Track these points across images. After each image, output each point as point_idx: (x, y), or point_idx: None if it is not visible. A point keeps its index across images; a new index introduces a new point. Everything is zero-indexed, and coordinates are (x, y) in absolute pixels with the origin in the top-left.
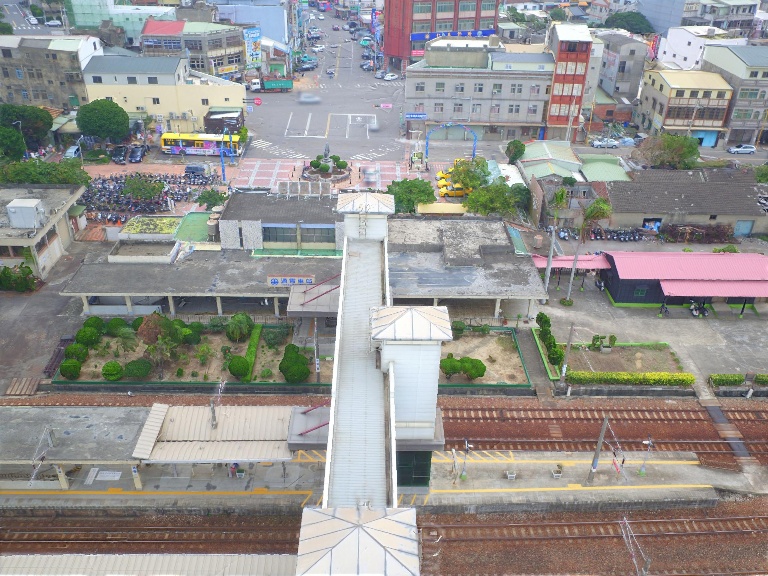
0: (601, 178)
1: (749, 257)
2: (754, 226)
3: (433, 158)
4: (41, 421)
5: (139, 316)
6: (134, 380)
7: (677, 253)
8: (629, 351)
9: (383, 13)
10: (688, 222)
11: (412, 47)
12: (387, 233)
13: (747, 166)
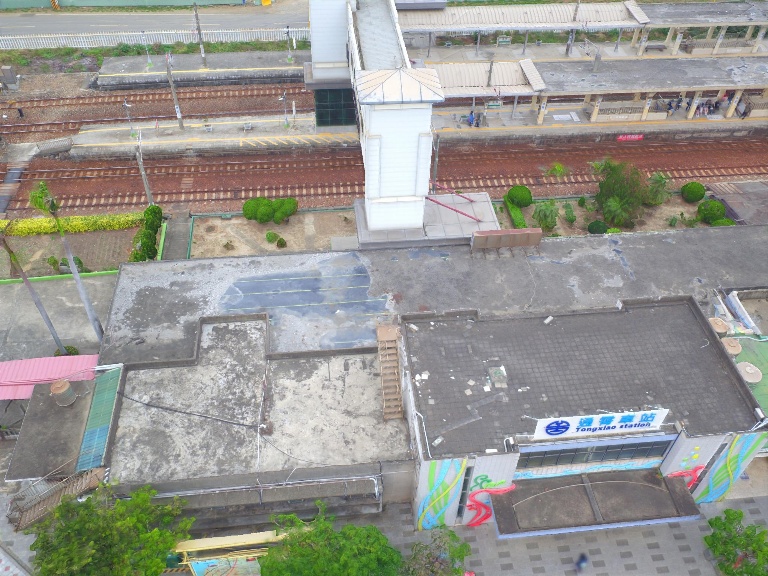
0: None
1: None
2: None
3: None
4: (623, 82)
5: None
6: None
7: None
8: (34, 273)
9: None
10: None
11: None
12: None
13: None
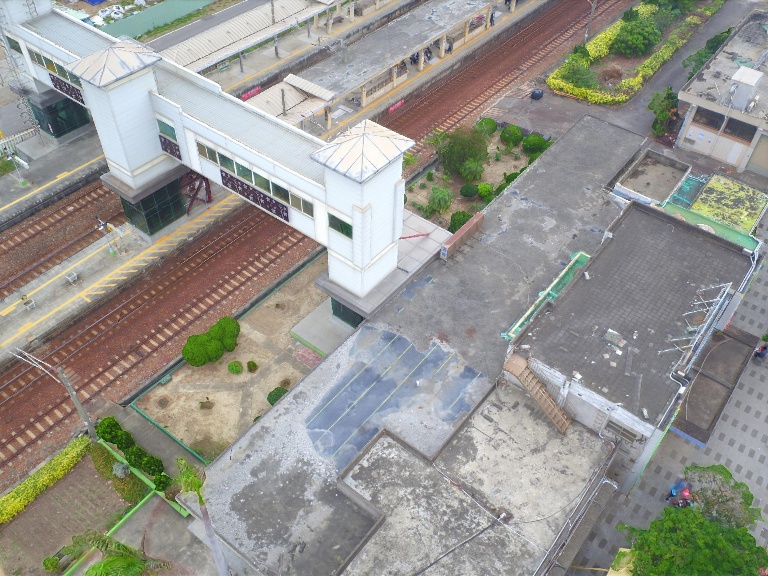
0: None
1: None
2: None
3: None
4: (377, 61)
5: None
6: None
7: None
8: None
9: None
10: None
11: None
12: (353, 216)
13: None
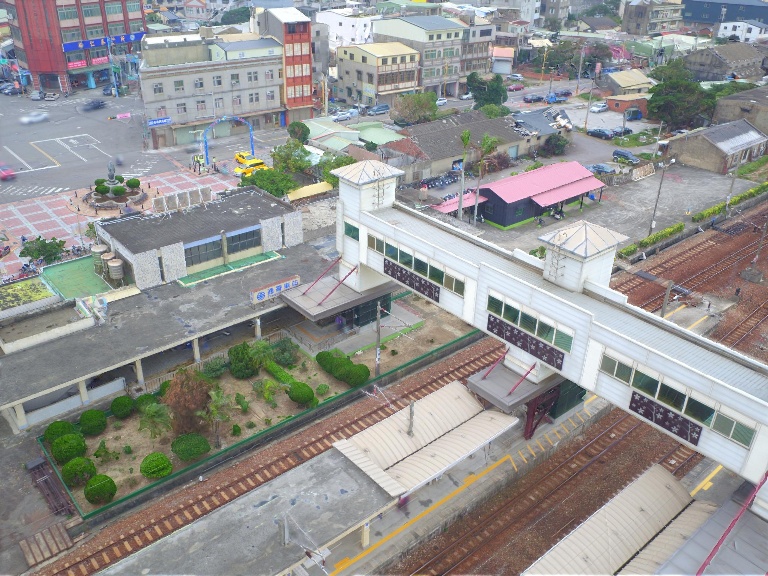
0: (386, 140)
1: (564, 164)
2: (519, 150)
3: None
4: (228, 530)
5: (100, 401)
6: (188, 464)
7: (518, 175)
8: None
9: (10, 25)
10: None
11: (67, 59)
12: None
13: (468, 110)
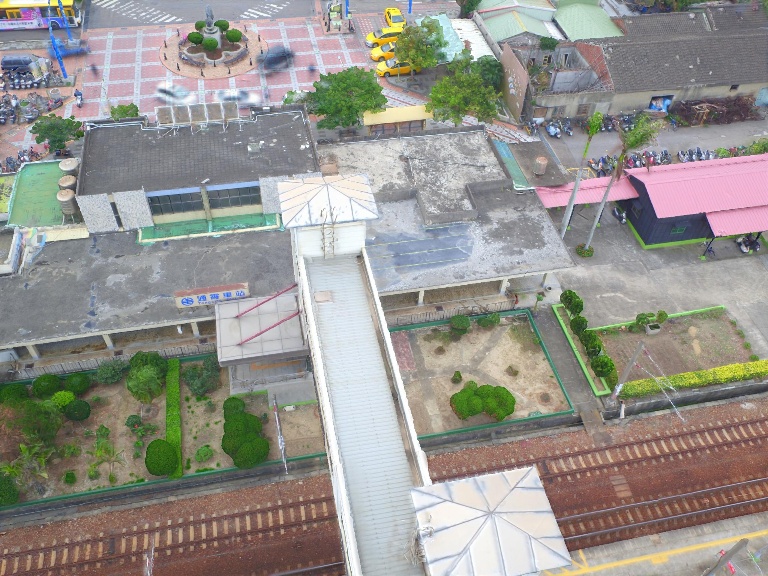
0: (584, 32)
1: None
2: None
3: (354, 7)
4: None
5: None
6: None
7: (717, 163)
8: (680, 326)
9: None
10: (704, 96)
11: None
12: None
13: None
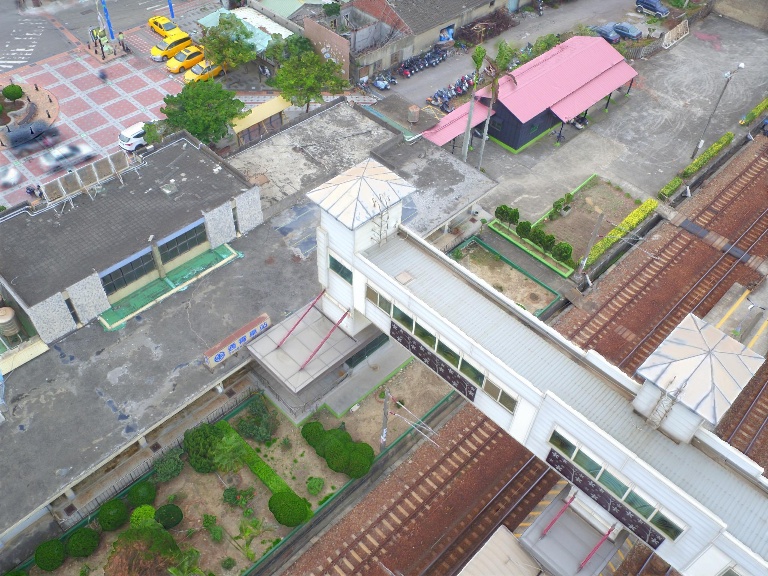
0: None
1: (588, 45)
2: None
3: None
4: None
5: (18, 540)
6: None
7: (531, 66)
8: (579, 201)
9: None
10: (474, 18)
11: None
12: None
13: None
